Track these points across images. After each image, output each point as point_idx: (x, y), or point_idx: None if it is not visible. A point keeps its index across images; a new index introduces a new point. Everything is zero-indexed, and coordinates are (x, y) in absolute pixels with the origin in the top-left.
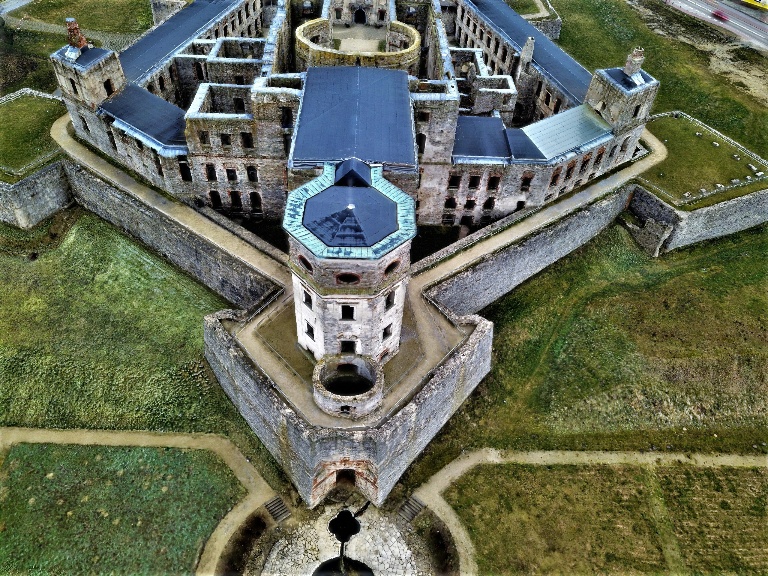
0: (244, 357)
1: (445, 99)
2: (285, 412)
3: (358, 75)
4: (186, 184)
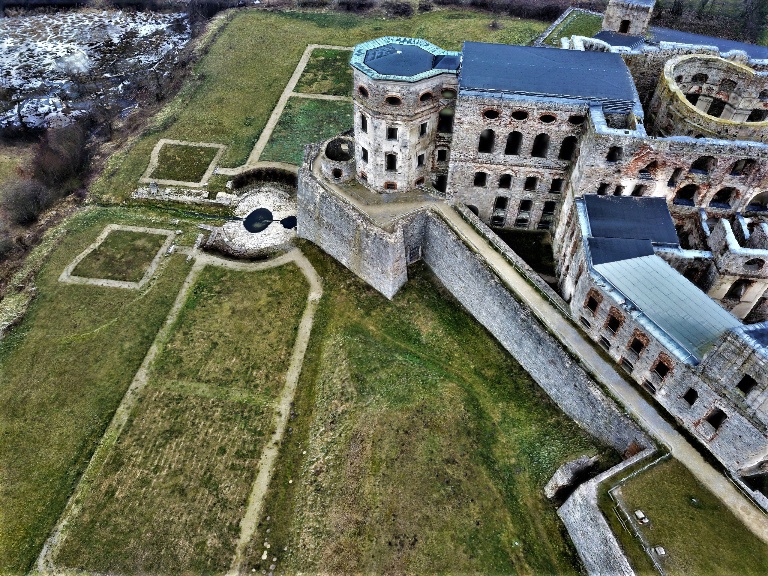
0: None
1: (595, 124)
2: None
3: (609, 71)
4: None
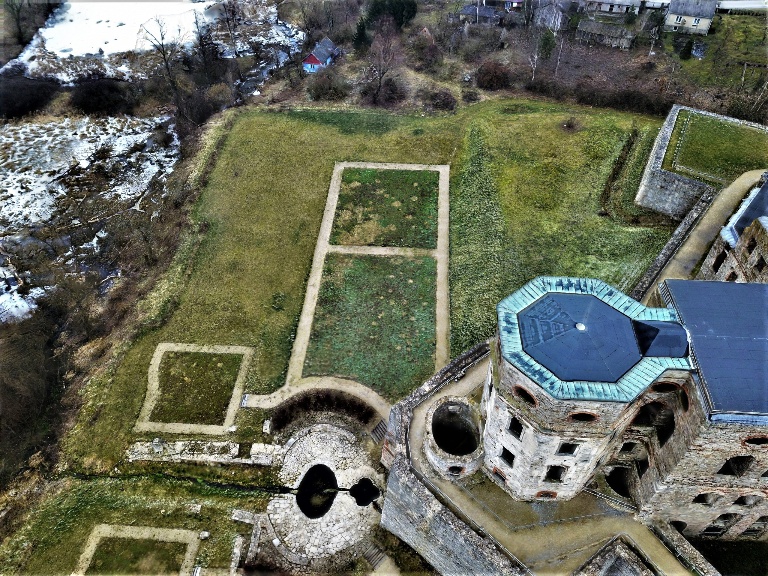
0: (486, 350)
1: None
2: (425, 386)
3: None
4: (712, 272)
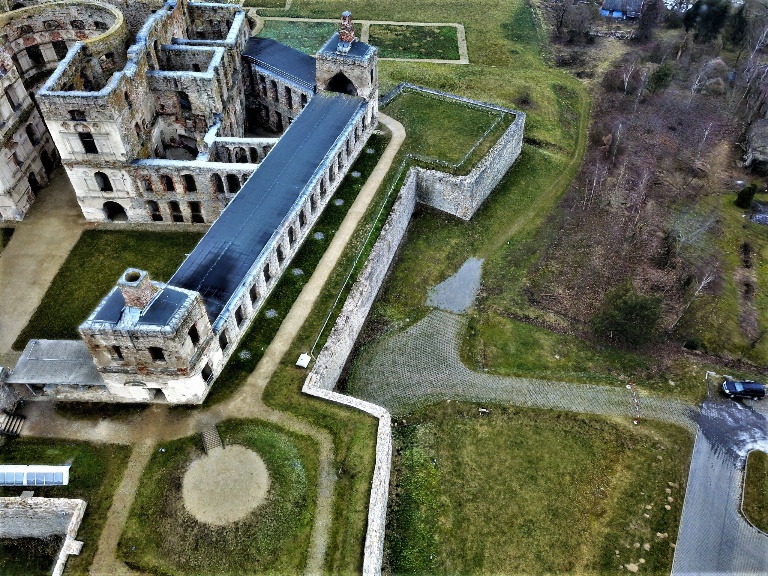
0: None
1: None
2: None
3: None
4: None
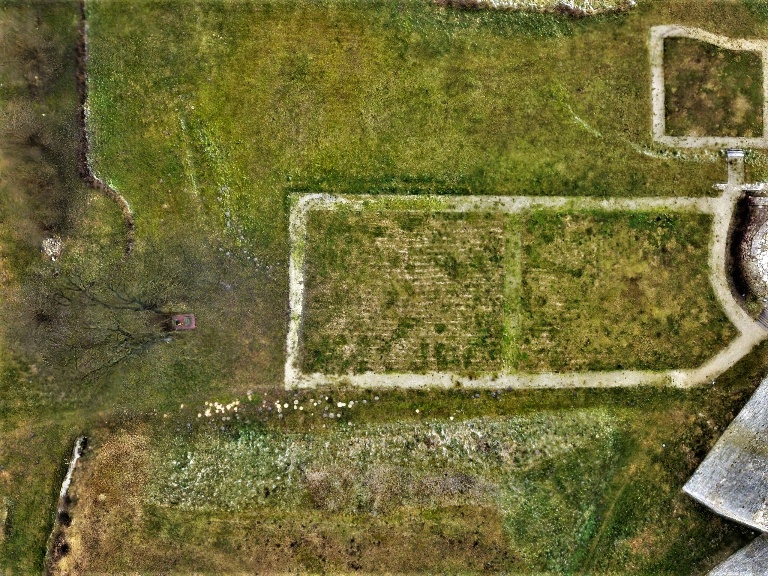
0: None
1: None
2: None
3: None
4: None
